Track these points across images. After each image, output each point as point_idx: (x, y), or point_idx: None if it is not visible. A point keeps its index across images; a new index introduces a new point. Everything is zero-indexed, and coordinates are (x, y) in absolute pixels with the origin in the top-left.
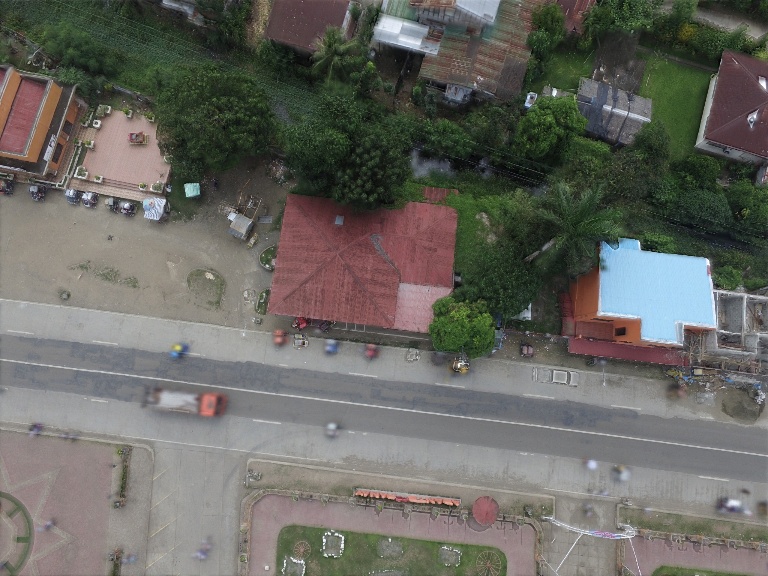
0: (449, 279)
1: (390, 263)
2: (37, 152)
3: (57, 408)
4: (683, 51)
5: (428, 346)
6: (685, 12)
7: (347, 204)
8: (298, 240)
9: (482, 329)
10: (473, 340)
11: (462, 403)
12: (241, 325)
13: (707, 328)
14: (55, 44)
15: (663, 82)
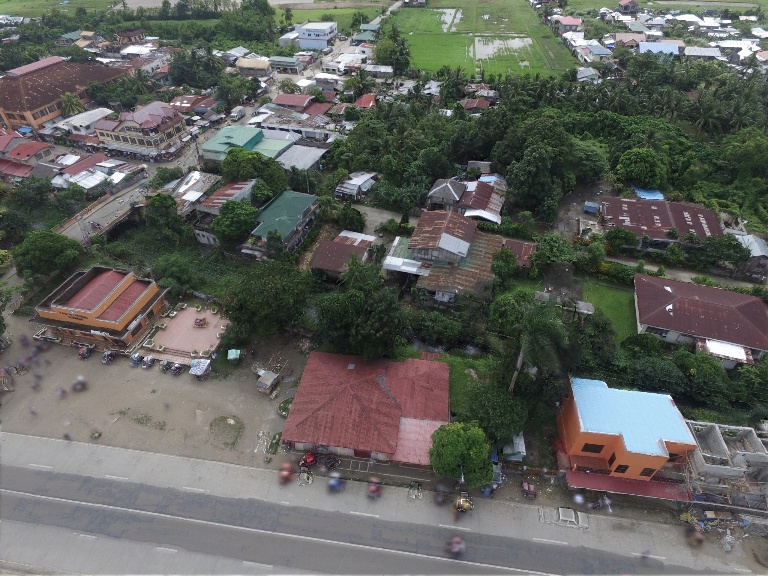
0: (445, 414)
1: (393, 399)
2: (124, 324)
3: (41, 543)
4: (608, 281)
5: (430, 487)
6: (597, 254)
7: (358, 358)
8: (315, 380)
9: (476, 438)
10: (469, 453)
11: (469, 547)
12: (250, 463)
13: (689, 447)
14: (165, 264)
15: (599, 297)
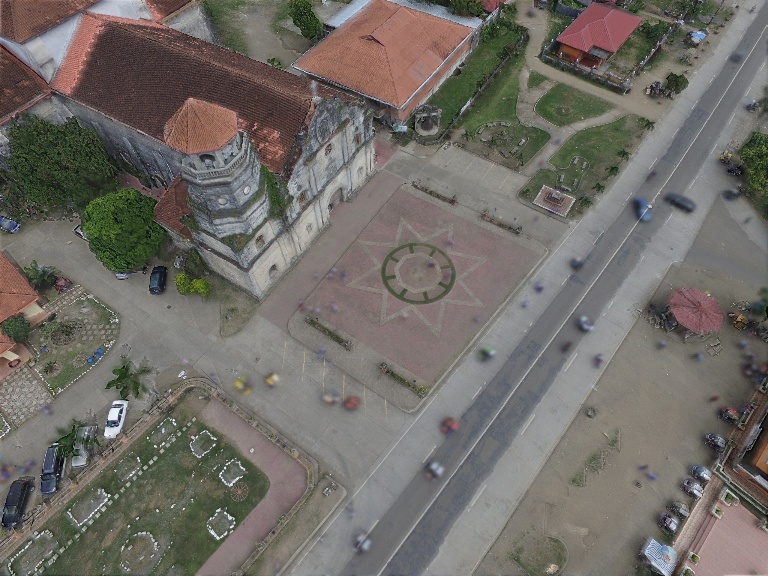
0: None
1: None
2: None
3: (489, 359)
4: None
5: None
6: None
7: None
8: None
9: None
10: None
11: None
12: (481, 571)
13: None
14: None
15: None
